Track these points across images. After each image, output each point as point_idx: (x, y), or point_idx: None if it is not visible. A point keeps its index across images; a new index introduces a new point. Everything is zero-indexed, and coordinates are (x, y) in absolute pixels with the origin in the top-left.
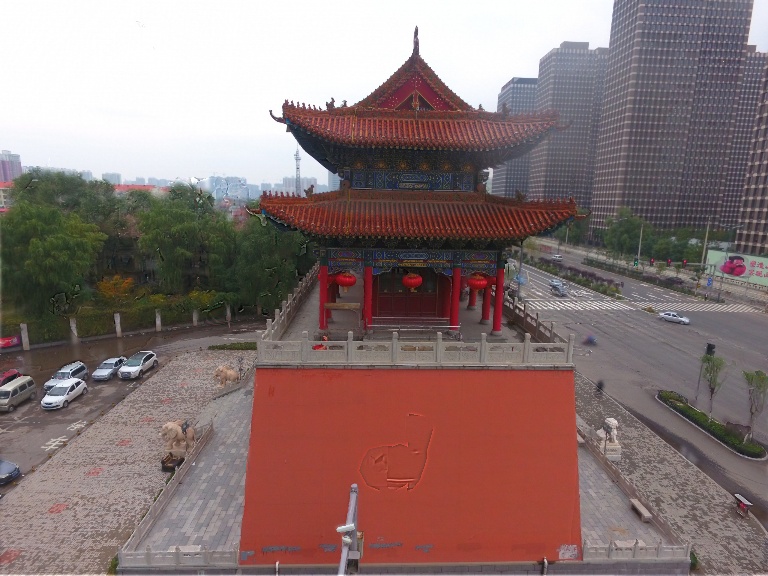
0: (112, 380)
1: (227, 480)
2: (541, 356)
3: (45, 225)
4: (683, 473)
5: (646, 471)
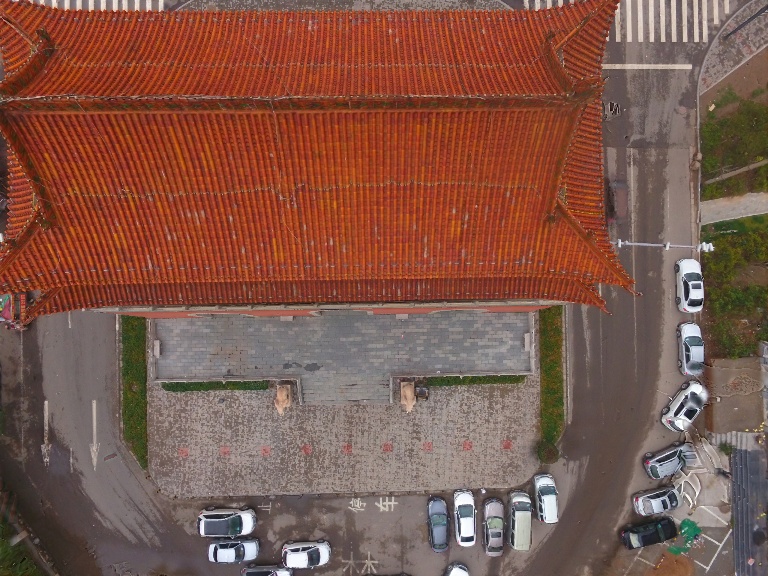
0: (255, 534)
1: (458, 341)
2: None
3: None
4: (425, 4)
5: None
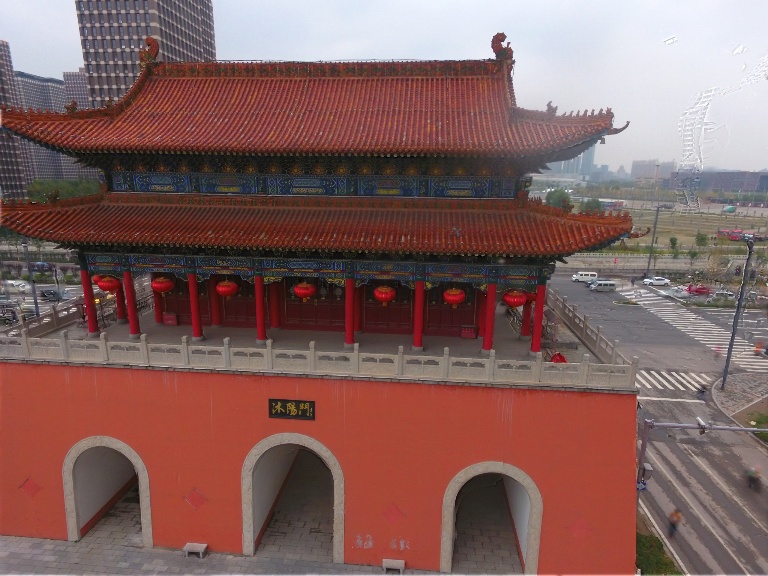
0: None
1: None
2: None
3: None
4: None
5: None
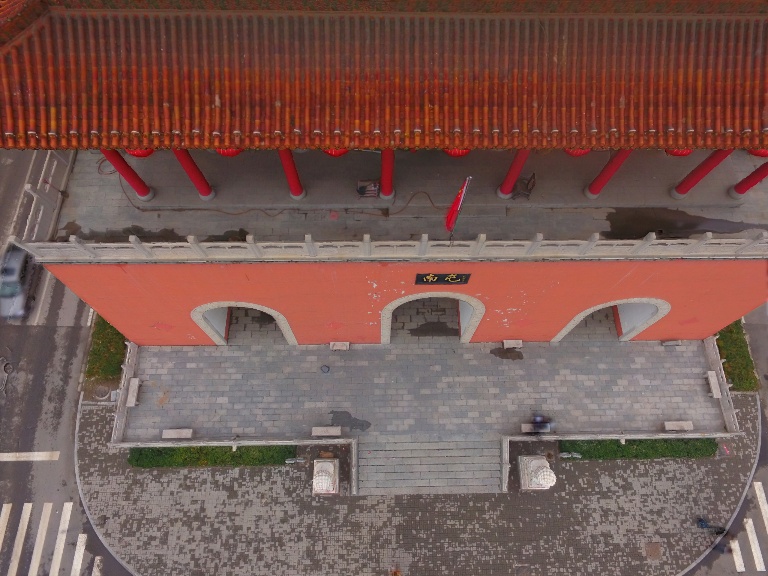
0: None
1: None
2: None
3: None
4: (282, 571)
5: (289, 515)
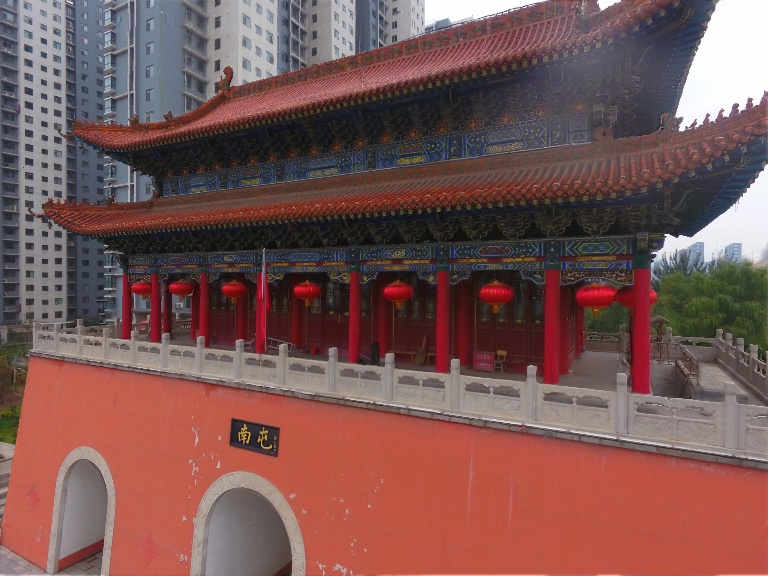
0: None
1: None
2: (66, 340)
3: (729, 285)
4: None
5: None
